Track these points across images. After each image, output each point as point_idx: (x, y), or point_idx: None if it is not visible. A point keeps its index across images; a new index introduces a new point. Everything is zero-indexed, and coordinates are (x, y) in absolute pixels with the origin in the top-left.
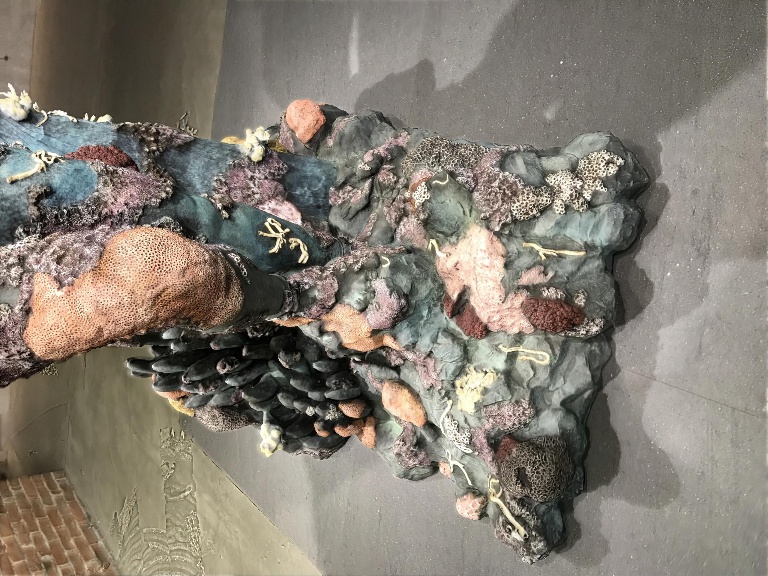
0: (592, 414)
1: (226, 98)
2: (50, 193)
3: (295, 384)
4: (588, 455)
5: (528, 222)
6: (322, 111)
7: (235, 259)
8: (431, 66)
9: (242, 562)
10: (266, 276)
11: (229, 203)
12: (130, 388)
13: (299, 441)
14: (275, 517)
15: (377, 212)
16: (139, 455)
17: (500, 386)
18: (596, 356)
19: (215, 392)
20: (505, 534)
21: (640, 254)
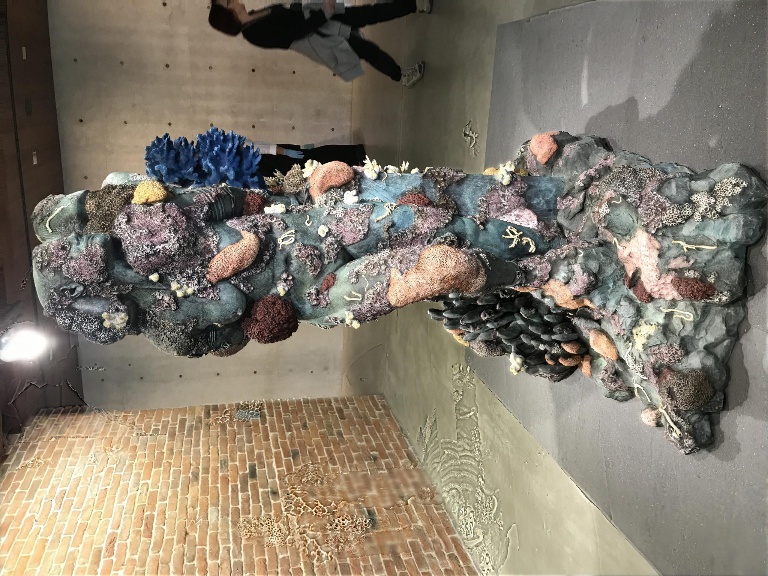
0: (732, 357)
1: (497, 116)
2: (393, 225)
3: (532, 329)
4: (729, 385)
5: (676, 227)
6: (555, 141)
7: (483, 257)
8: (636, 102)
9: (511, 465)
10: (504, 263)
11: (484, 220)
12: (430, 333)
13: (537, 367)
14: (530, 428)
15: (587, 215)
16: (437, 384)
17: (659, 334)
18: (731, 317)
19: (481, 331)
20: (669, 434)
21: (765, 247)
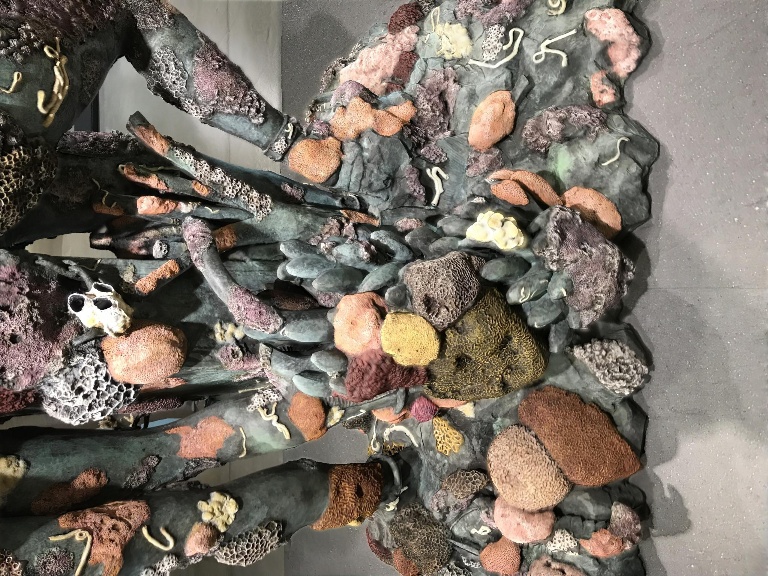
0: None
1: None
2: None
3: (443, 221)
4: None
5: None
6: None
7: None
8: None
9: None
10: None
11: None
12: None
13: (537, 233)
14: None
15: None
16: None
17: None
18: None
19: (389, 266)
20: None
21: None
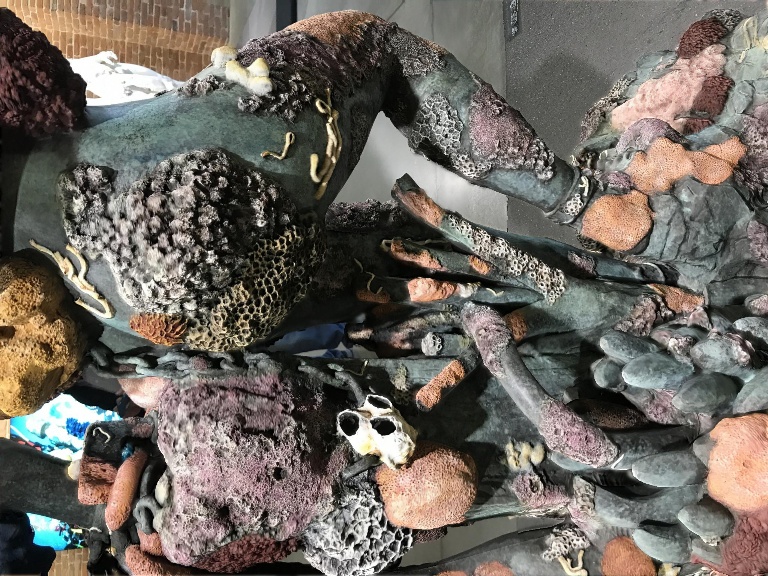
0: None
1: None
2: None
3: None
4: None
5: None
6: None
7: None
8: None
9: None
10: None
11: None
12: None
13: None
14: None
15: None
16: None
17: None
18: None
19: None
20: None
21: None
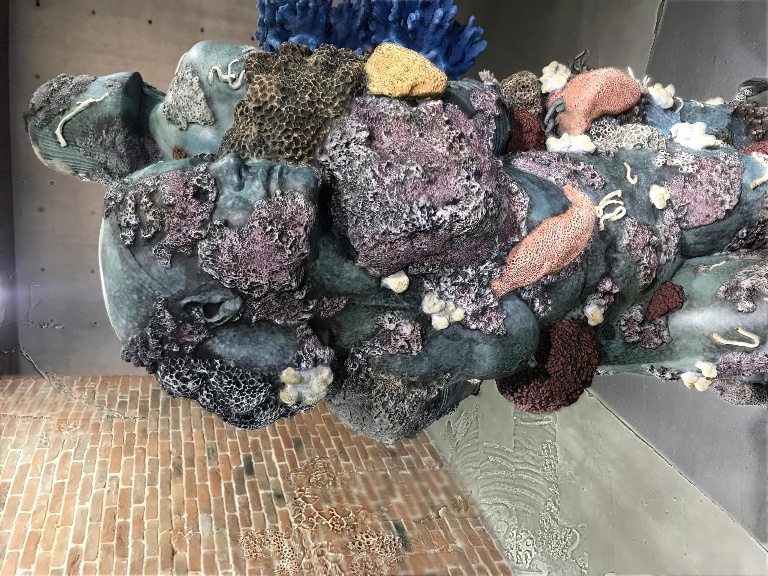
0: None
1: (673, 44)
2: None
3: None
4: None
5: None
6: None
7: None
8: None
9: (614, 501)
10: None
11: None
12: None
13: None
14: (693, 475)
15: None
16: None
17: None
18: None
19: None
20: None
21: None
